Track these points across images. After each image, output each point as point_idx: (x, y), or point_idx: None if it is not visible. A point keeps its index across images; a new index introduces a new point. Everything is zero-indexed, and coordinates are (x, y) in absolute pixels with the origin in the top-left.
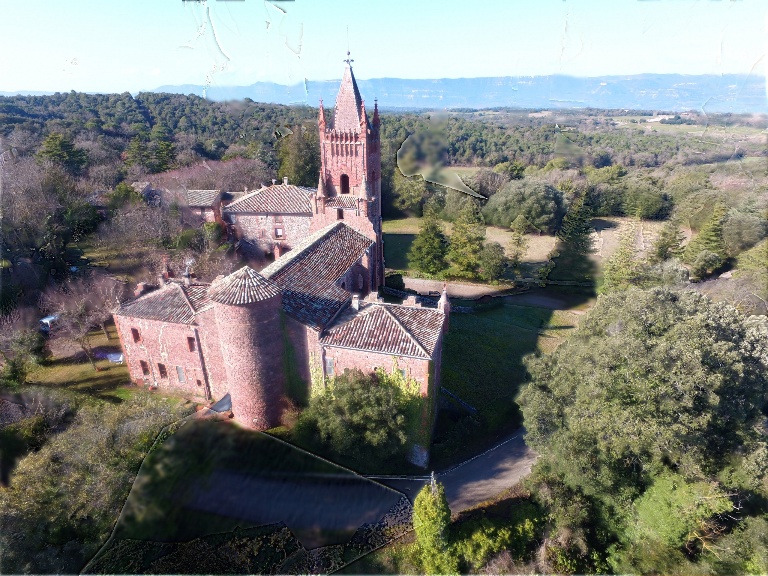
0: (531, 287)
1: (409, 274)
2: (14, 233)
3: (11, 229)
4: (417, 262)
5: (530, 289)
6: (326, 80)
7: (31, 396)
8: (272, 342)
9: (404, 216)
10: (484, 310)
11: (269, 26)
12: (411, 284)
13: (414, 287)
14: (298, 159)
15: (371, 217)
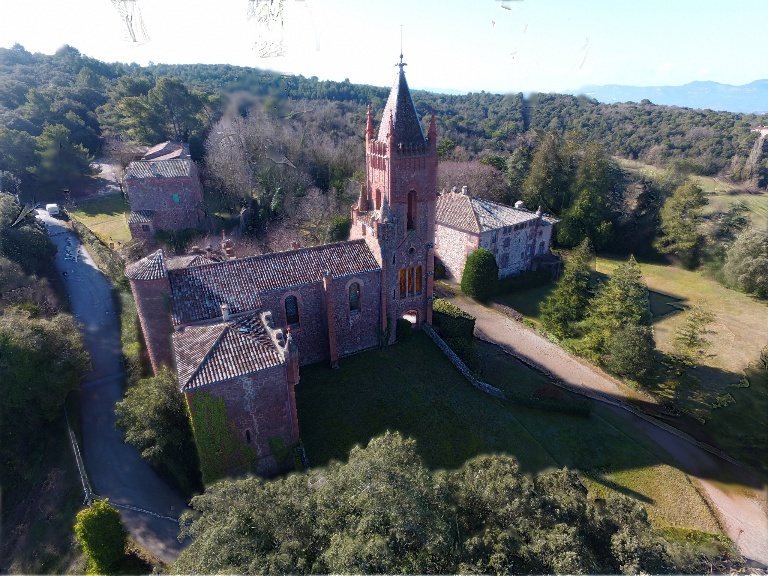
0: (684, 416)
1: (536, 328)
2: (222, 195)
3: (221, 192)
4: (543, 316)
5: (681, 418)
6: (564, 83)
7: (121, 300)
8: (155, 318)
9: (665, 262)
10: (527, 404)
11: (494, 26)
12: (523, 339)
13: (521, 344)
14: (542, 170)
15: (383, 240)
